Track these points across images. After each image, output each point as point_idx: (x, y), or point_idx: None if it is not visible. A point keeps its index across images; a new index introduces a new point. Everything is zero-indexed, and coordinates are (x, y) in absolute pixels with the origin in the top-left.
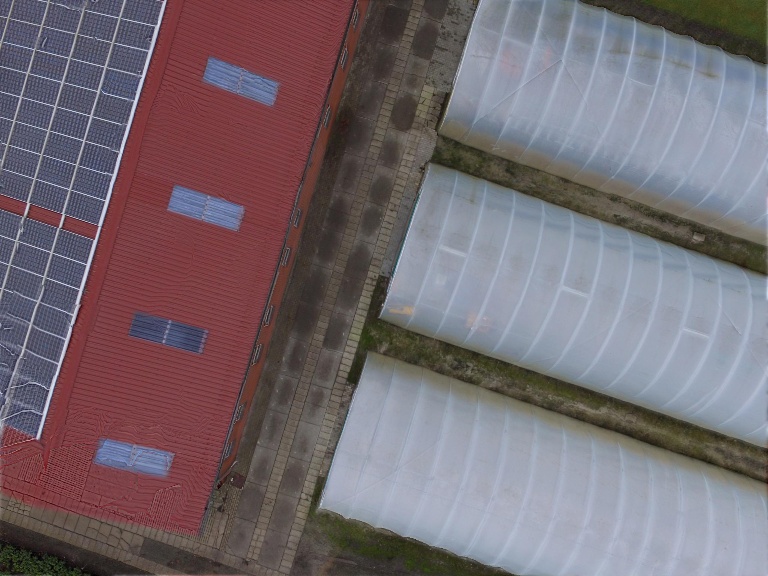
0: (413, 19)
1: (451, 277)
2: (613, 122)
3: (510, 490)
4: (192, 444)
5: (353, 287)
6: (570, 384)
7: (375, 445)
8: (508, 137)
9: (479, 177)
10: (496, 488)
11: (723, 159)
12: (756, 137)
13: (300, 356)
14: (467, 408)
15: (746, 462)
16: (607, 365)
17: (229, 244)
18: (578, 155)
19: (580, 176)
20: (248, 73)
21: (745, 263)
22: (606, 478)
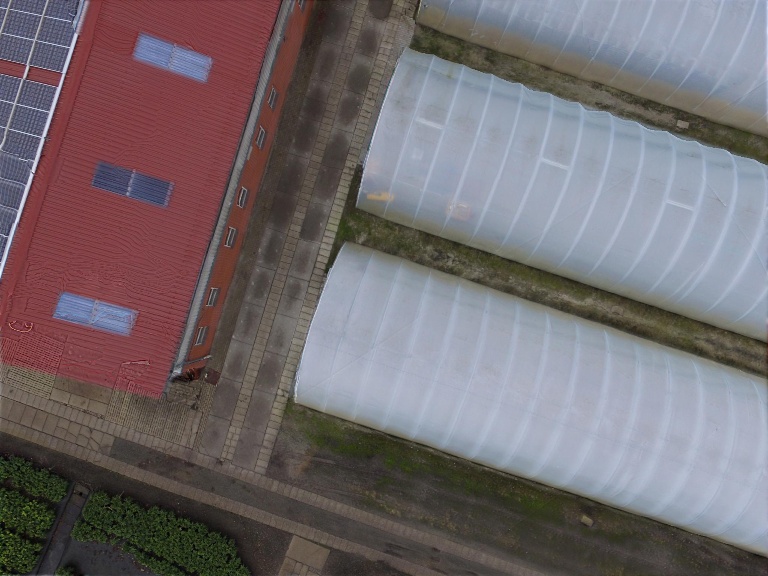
0: None
1: (428, 150)
2: None
3: (491, 369)
4: (157, 302)
5: (330, 176)
6: (554, 275)
7: (351, 322)
8: (486, 18)
9: None
10: (476, 366)
11: (703, 31)
12: (736, 7)
13: (276, 247)
14: (447, 292)
15: (737, 355)
16: (590, 243)
17: (196, 93)
18: (557, 35)
19: (560, 62)
20: None
21: (730, 150)
22: (591, 359)
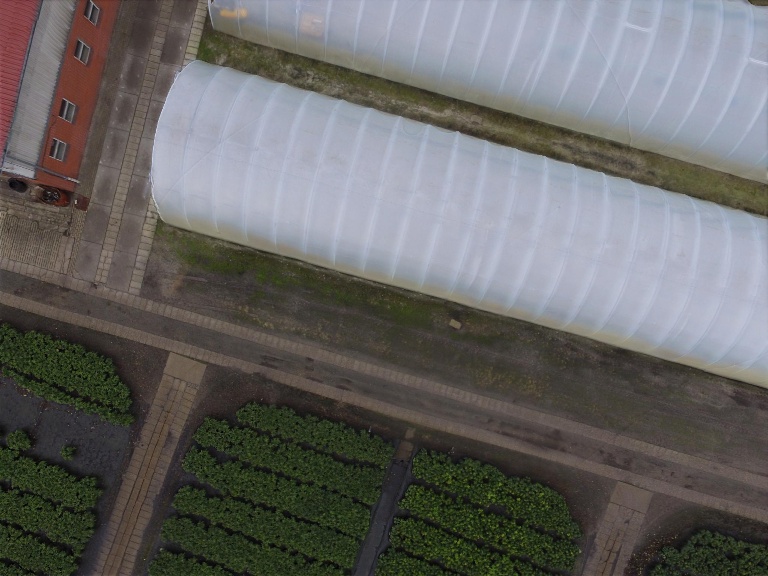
0: None
1: None
2: None
3: (337, 158)
4: None
5: (188, 0)
6: (412, 87)
7: (197, 119)
8: None
9: None
10: (322, 156)
11: None
12: None
13: (138, 72)
14: (300, 98)
15: (595, 157)
16: (433, 39)
17: None
18: None
19: None
20: None
21: None
22: (438, 150)
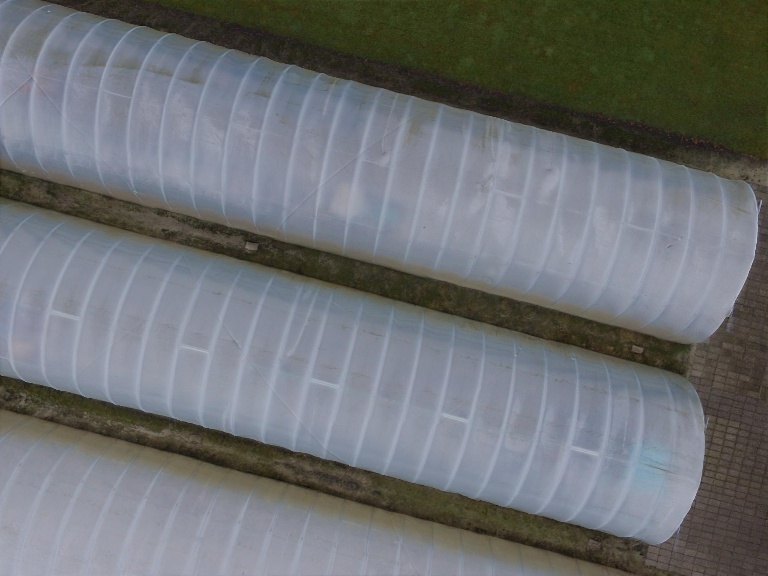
0: None
1: None
2: (99, 137)
3: (10, 527)
4: None
5: None
6: (127, 408)
7: None
8: (20, 159)
9: (18, 201)
10: None
11: (216, 167)
12: (241, 142)
13: None
14: None
15: (319, 477)
16: (121, 388)
17: None
18: (93, 172)
19: (115, 193)
20: None
21: (300, 270)
22: (124, 507)
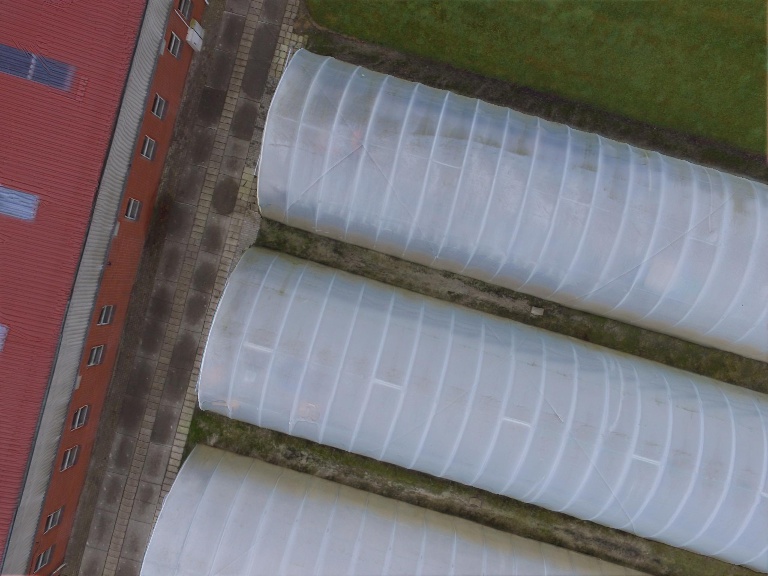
0: (231, 100)
1: (259, 374)
2: (423, 206)
3: None
4: None
5: (180, 378)
6: (409, 470)
7: (185, 554)
8: (325, 221)
9: (306, 259)
10: None
11: (539, 239)
12: (569, 216)
13: (127, 452)
14: None
15: (598, 544)
16: (431, 457)
17: None
18: (398, 237)
19: (408, 255)
20: (2, 188)
21: (586, 337)
22: None
